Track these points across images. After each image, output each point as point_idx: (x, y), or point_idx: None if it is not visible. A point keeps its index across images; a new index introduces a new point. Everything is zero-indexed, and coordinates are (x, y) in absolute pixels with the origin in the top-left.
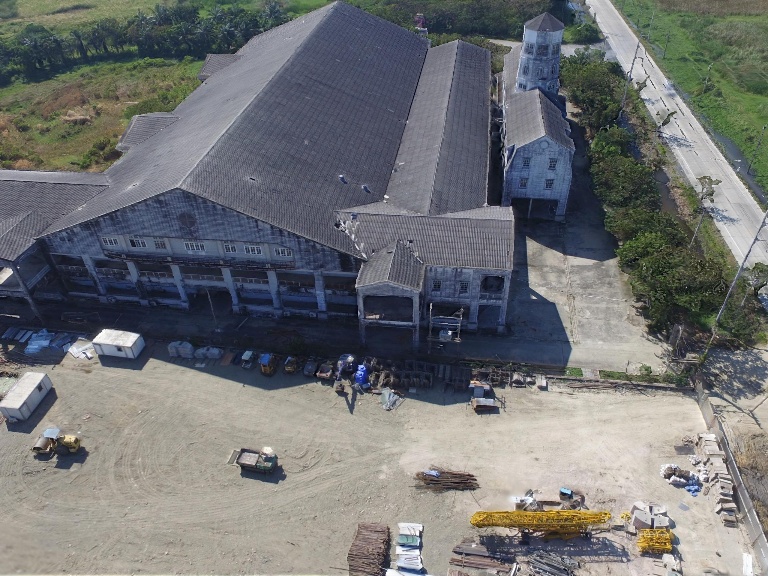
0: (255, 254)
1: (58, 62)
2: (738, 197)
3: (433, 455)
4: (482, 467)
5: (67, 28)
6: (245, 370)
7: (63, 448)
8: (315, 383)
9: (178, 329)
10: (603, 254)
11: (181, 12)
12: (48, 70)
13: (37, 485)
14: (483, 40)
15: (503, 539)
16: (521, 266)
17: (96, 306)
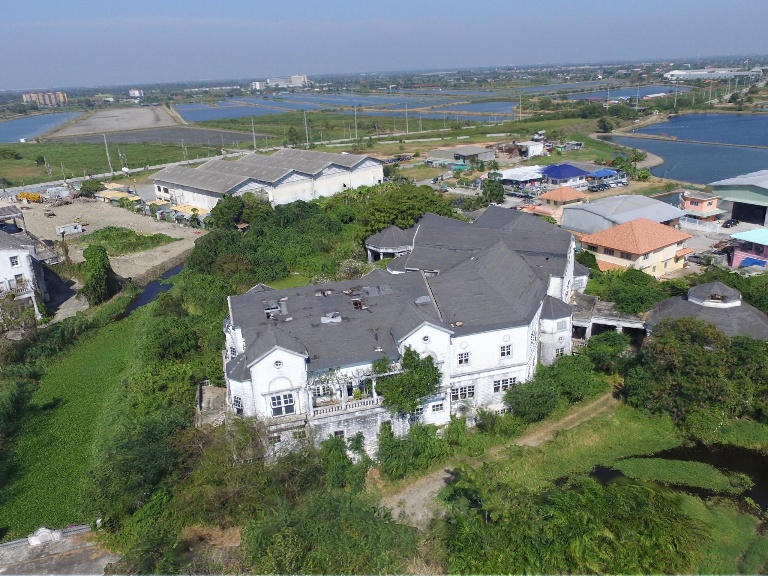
0: None
1: None
2: None
3: None
4: None
5: None
6: None
7: None
8: None
9: None
10: None
11: None
12: None
13: None
14: None
15: None
16: None
17: None
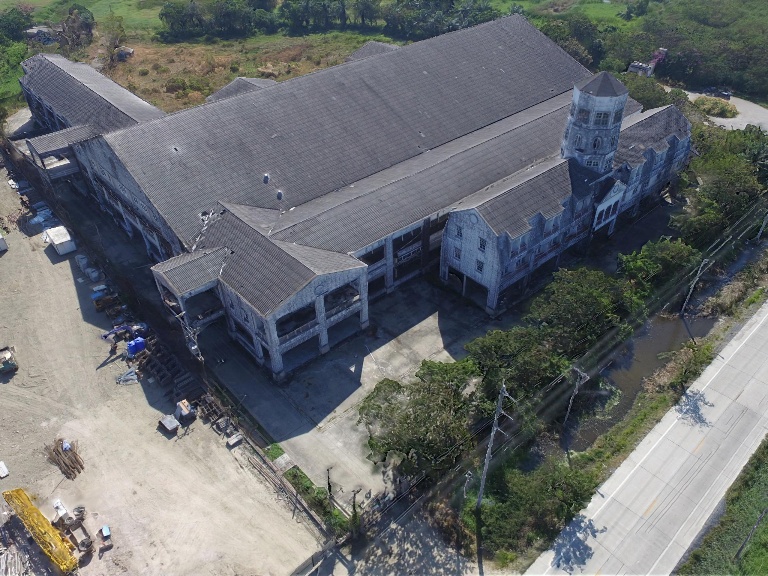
0: (146, 211)
1: (322, 24)
2: (759, 399)
3: (88, 434)
4: (97, 467)
5: None
6: None
7: None
8: None
9: (109, 249)
10: None
11: None
12: (309, 29)
13: None
14: (679, 94)
15: None
16: (388, 335)
17: (97, 210)
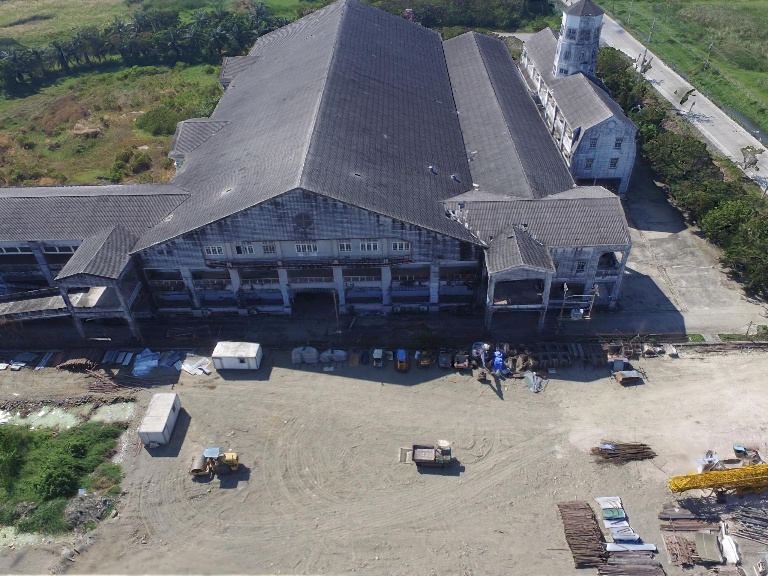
0: (371, 251)
1: (38, 75)
2: None
3: (599, 430)
4: (651, 436)
5: (33, 40)
6: (377, 369)
7: (225, 467)
8: (454, 374)
9: (288, 335)
10: (674, 226)
11: (163, 17)
12: (30, 84)
13: (208, 508)
14: (485, 31)
15: (700, 501)
16: None
17: (190, 321)
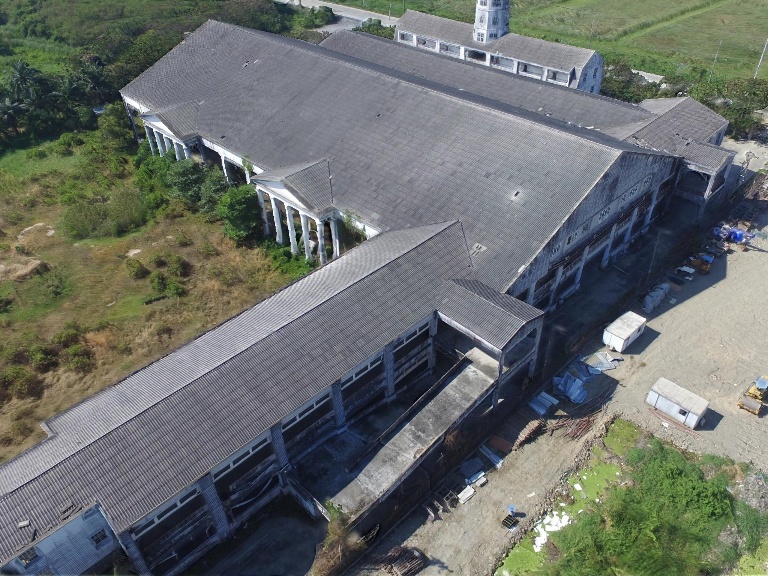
0: (633, 194)
1: None
2: None
3: None
4: None
5: None
6: (694, 281)
7: None
8: (728, 256)
9: (606, 302)
10: None
11: None
12: None
13: None
14: None
15: None
16: None
17: None
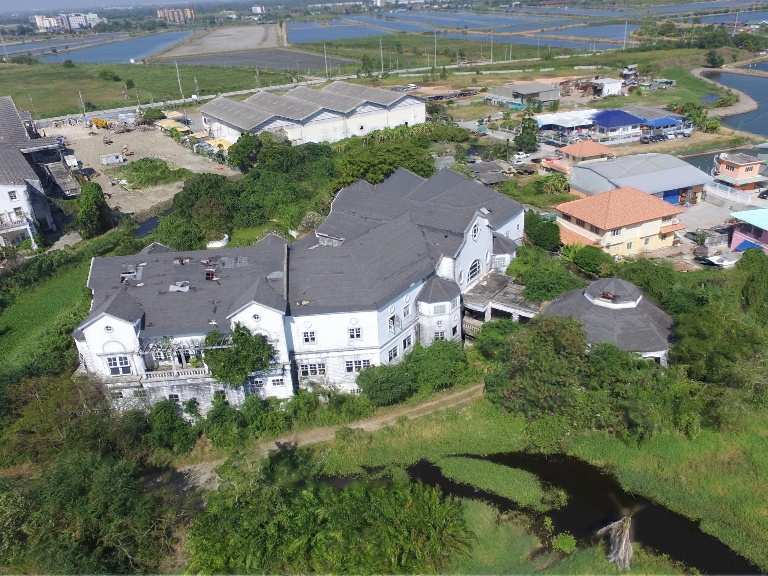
0: None
1: None
2: None
3: None
4: None
5: None
6: None
7: None
8: None
9: None
10: None
11: None
12: None
13: None
14: None
15: None
16: None
17: None
